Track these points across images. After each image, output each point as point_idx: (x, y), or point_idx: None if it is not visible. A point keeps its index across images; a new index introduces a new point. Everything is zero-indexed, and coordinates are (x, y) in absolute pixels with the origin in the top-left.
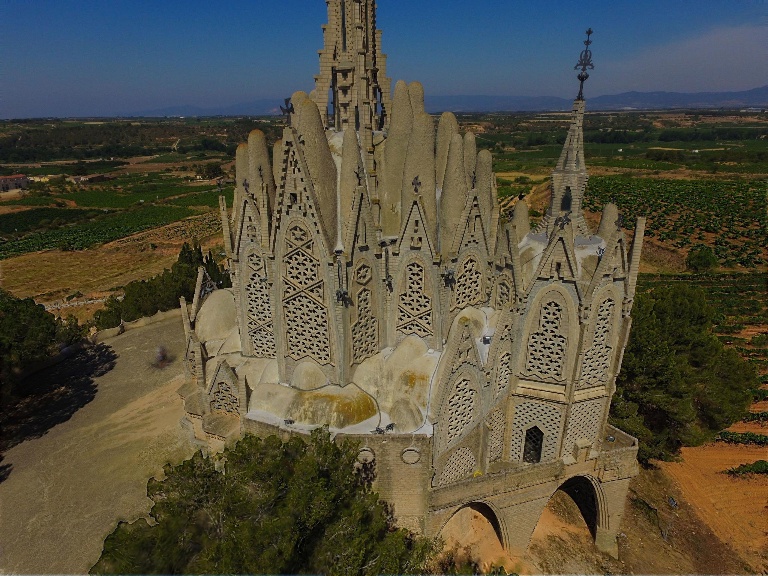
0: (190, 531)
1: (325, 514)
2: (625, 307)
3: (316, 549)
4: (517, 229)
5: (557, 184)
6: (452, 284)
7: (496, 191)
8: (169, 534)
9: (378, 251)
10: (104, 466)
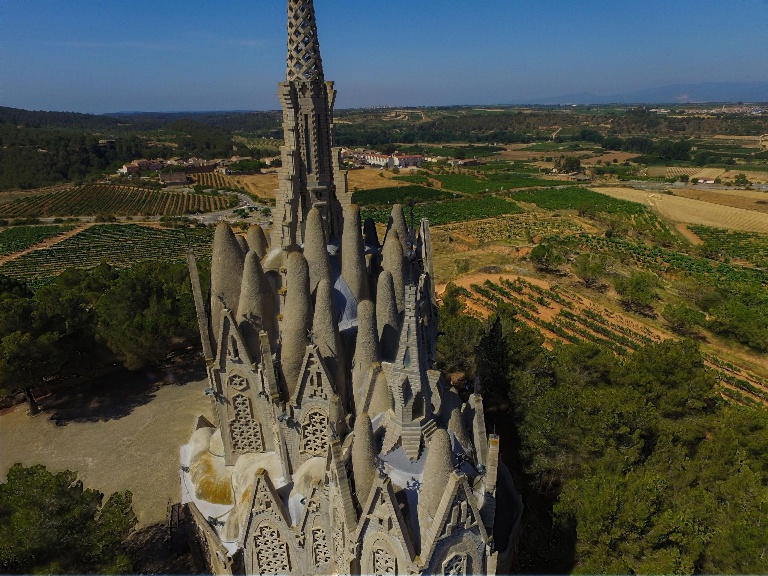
0: (5, 510)
1: (7, 557)
2: (408, 575)
3: (24, 575)
4: (373, 402)
5: (389, 375)
6: (298, 428)
7: None
8: None
9: (251, 367)
10: (177, 425)
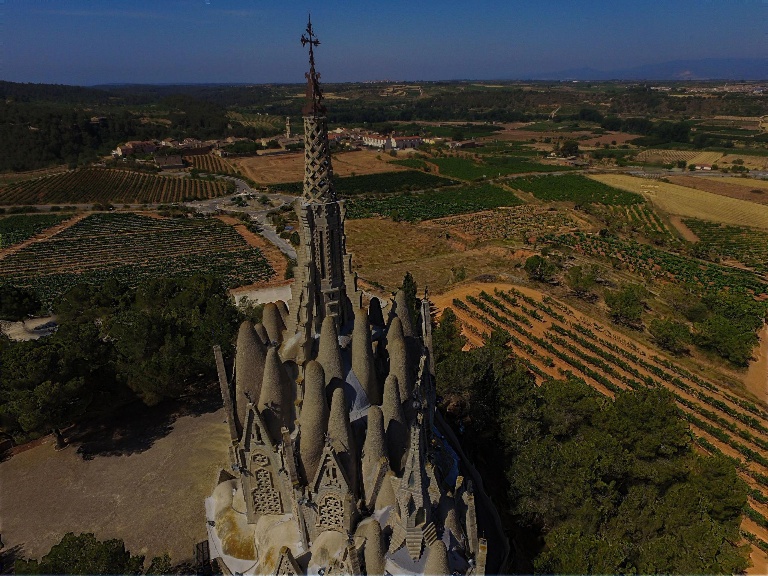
0: (61, 575)
1: None
2: None
3: None
4: (381, 496)
5: (396, 487)
6: (315, 507)
7: None
8: (35, 575)
9: (272, 449)
10: (195, 460)
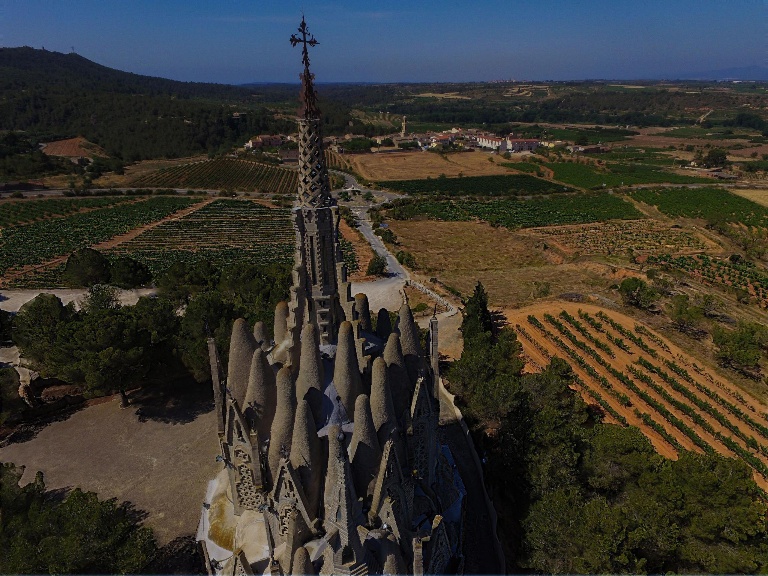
0: None
1: (53, 575)
2: None
3: None
4: None
5: None
6: (278, 515)
7: (386, 464)
8: None
9: None
10: None
